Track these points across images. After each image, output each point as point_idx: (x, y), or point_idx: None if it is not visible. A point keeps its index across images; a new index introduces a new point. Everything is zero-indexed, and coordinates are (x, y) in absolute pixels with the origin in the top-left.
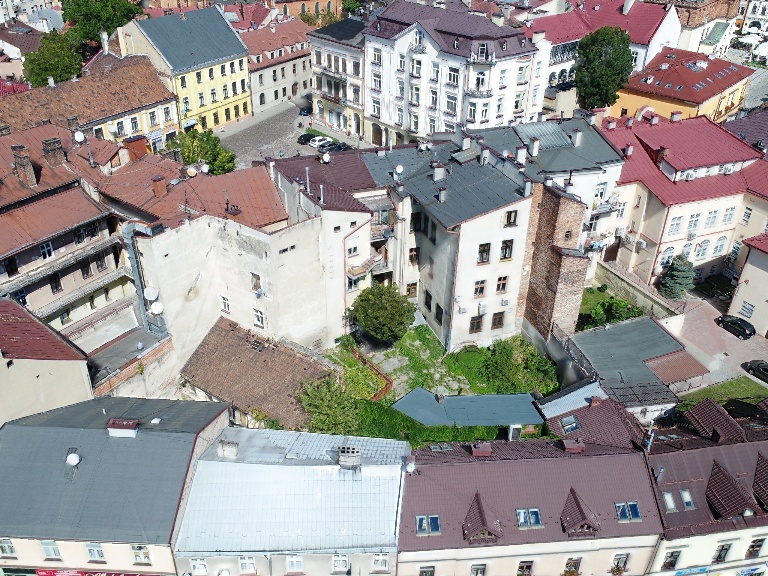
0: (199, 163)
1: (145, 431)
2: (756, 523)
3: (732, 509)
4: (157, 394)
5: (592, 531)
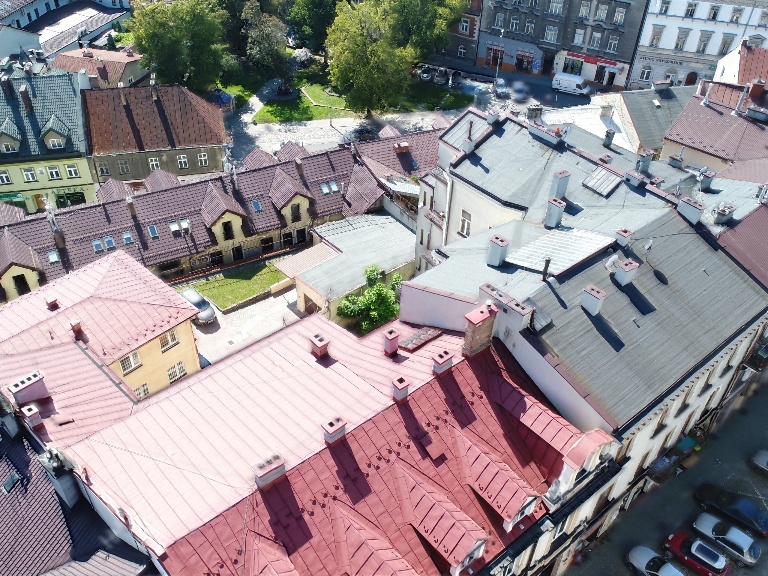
0: None
1: (651, 90)
2: None
3: None
4: None
5: None
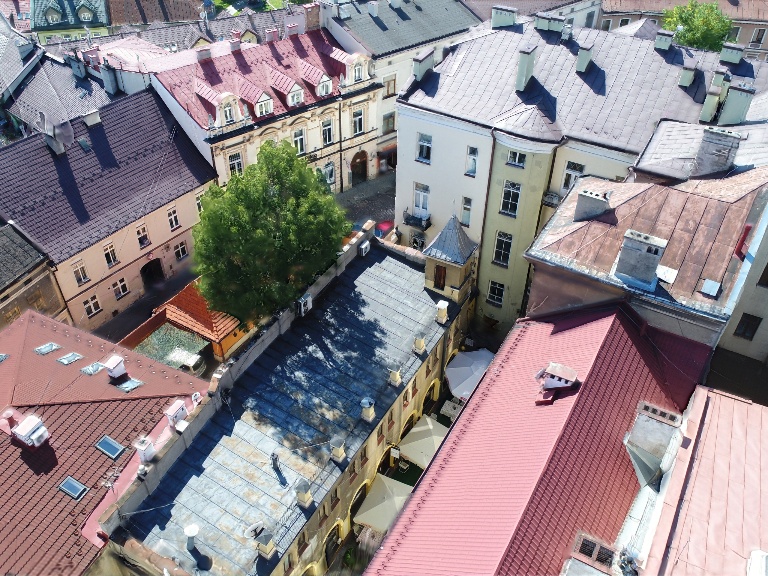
0: None
1: None
2: None
3: None
4: None
5: None
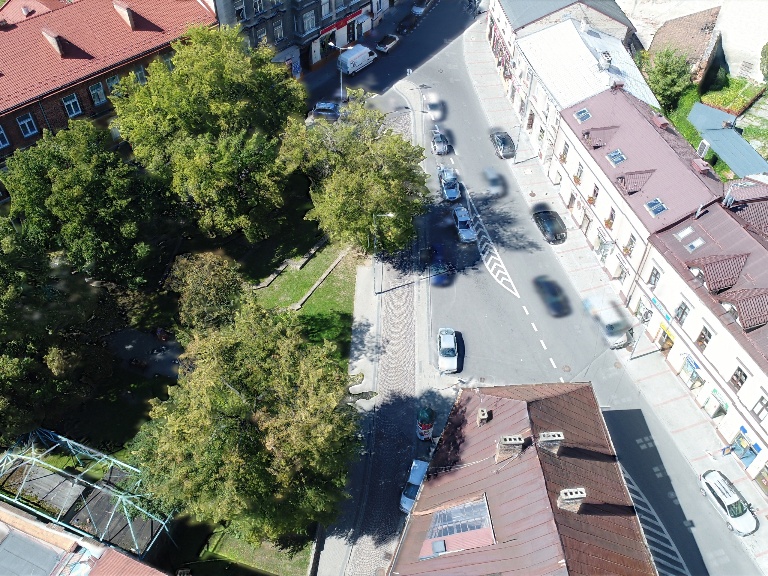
0: None
1: None
2: (702, 295)
3: (696, 262)
4: (639, 22)
5: (627, 192)
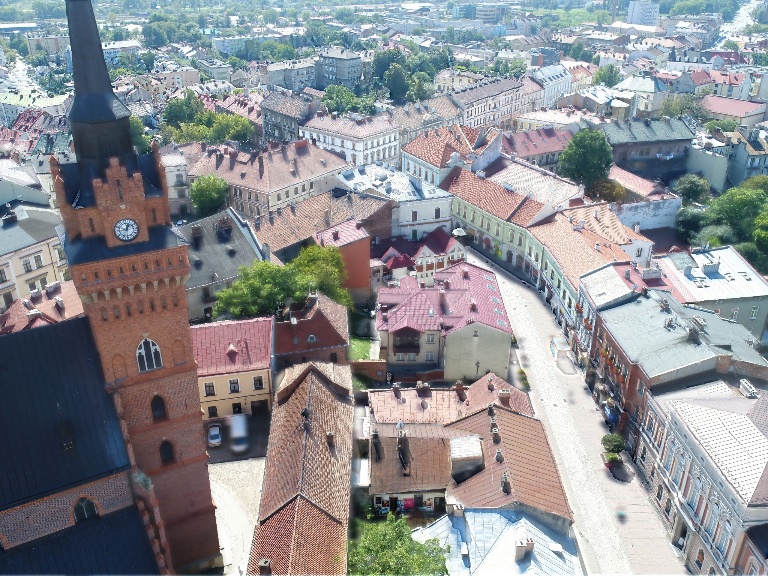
0: (210, 149)
1: None
2: None
3: None
4: None
5: None
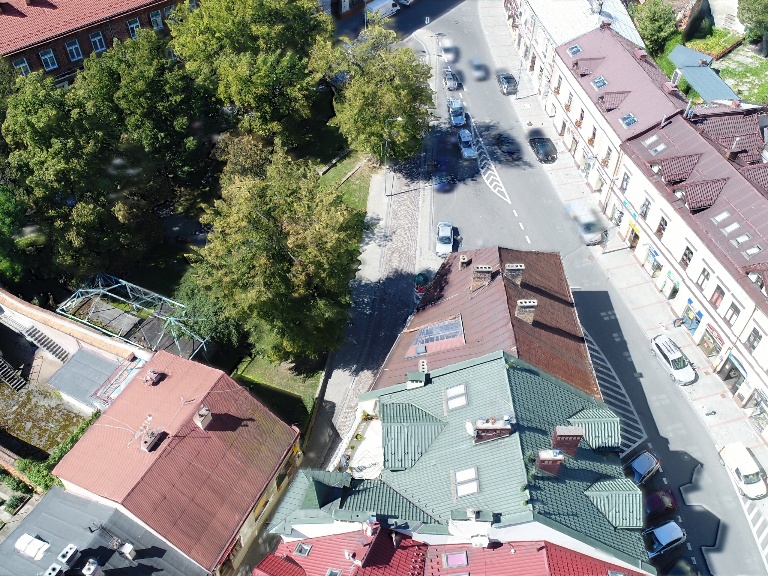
0: None
1: None
2: (660, 187)
3: None
4: None
5: None
